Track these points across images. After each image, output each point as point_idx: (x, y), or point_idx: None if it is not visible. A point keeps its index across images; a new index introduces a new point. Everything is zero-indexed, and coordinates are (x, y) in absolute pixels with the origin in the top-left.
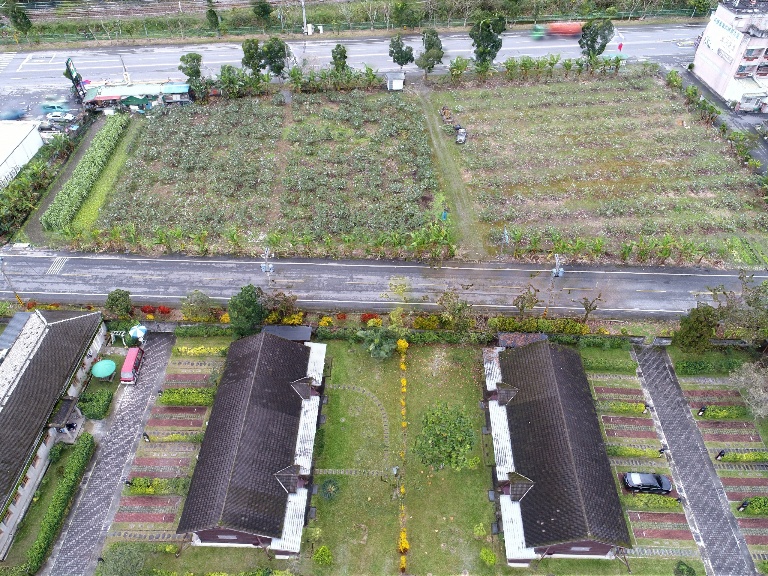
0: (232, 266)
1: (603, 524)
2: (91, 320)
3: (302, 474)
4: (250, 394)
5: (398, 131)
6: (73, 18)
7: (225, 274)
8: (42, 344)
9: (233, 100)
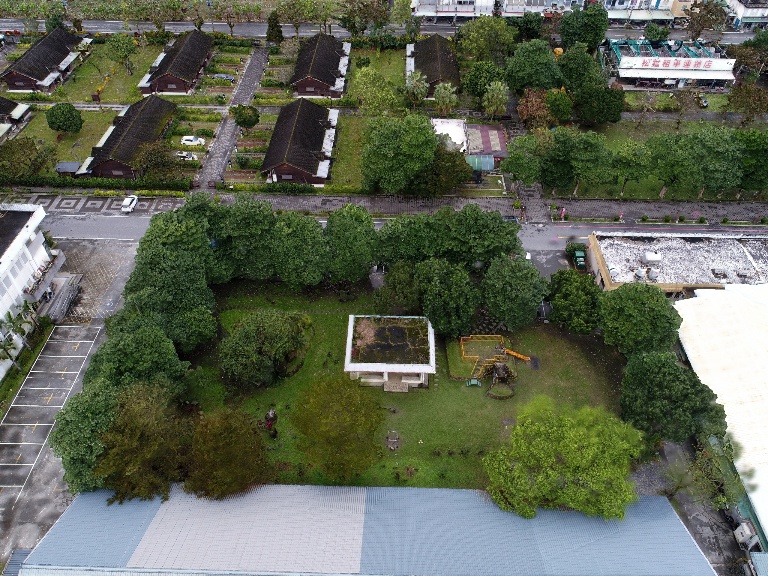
0: None
1: (179, 72)
2: None
3: (60, 70)
4: (41, 42)
5: None
6: None
7: None
8: None
9: None
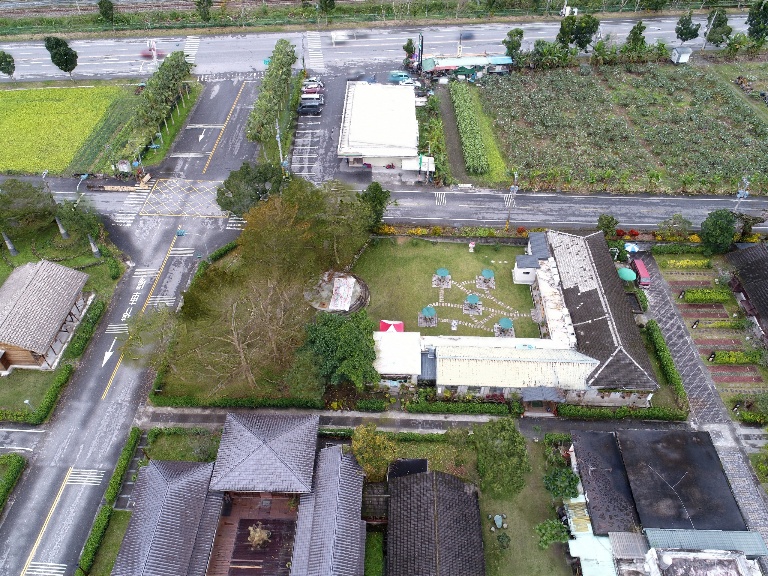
0: (657, 201)
1: None
2: (602, 237)
3: None
4: None
5: (713, 96)
6: (343, 2)
7: (656, 207)
8: (591, 252)
9: (549, 70)
